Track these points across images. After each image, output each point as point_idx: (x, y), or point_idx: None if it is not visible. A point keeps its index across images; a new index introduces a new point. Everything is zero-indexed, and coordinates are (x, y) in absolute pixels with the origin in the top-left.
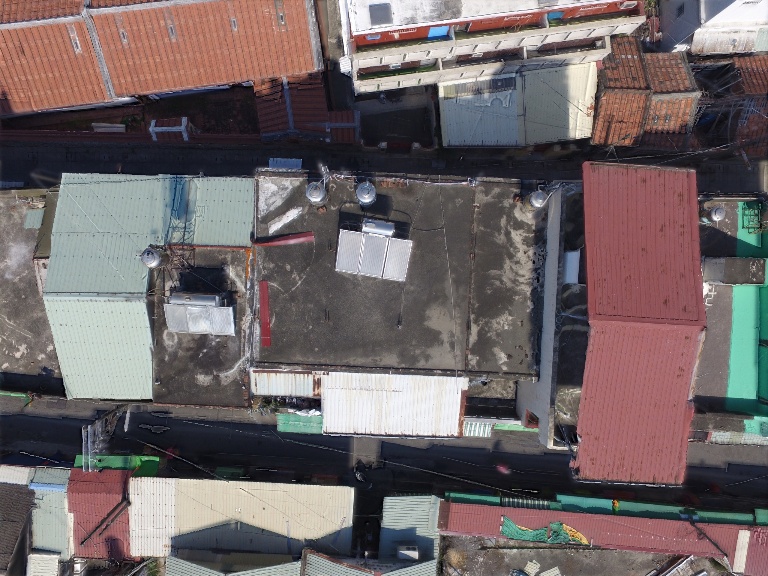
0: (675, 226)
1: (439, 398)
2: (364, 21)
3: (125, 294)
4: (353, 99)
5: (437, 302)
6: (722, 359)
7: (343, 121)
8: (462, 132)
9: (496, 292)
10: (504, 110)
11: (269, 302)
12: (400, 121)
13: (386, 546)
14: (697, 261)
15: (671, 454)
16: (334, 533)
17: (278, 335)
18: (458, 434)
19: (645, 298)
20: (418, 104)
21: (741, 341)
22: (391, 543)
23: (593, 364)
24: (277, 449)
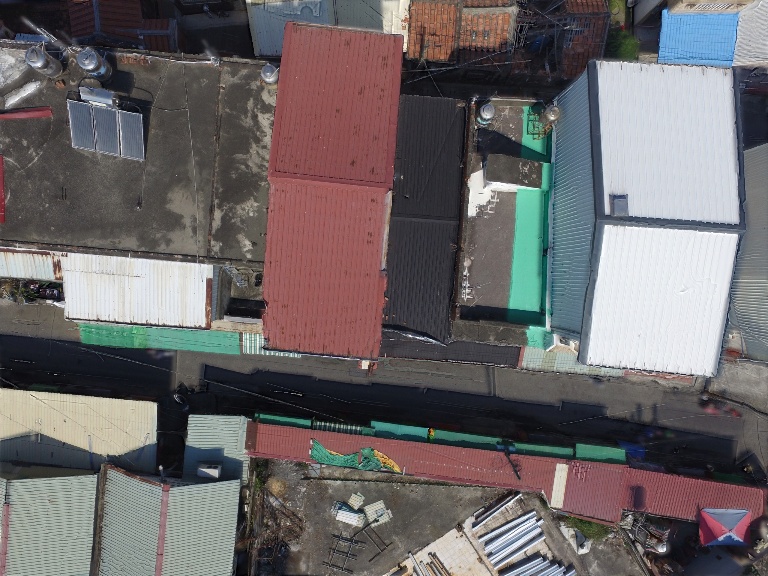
0: (374, 89)
1: (184, 286)
2: None
3: None
4: (180, 12)
5: (180, 185)
6: (504, 269)
7: (156, 28)
8: (273, 41)
9: (241, 177)
10: (315, 19)
11: (4, 178)
12: (229, 37)
13: (191, 465)
14: (393, 125)
15: (365, 327)
16: (137, 449)
17: (13, 212)
18: (205, 325)
19: (331, 158)
20: (247, 20)
21: (524, 251)
22: (196, 462)
23: (276, 225)
24: (97, 368)
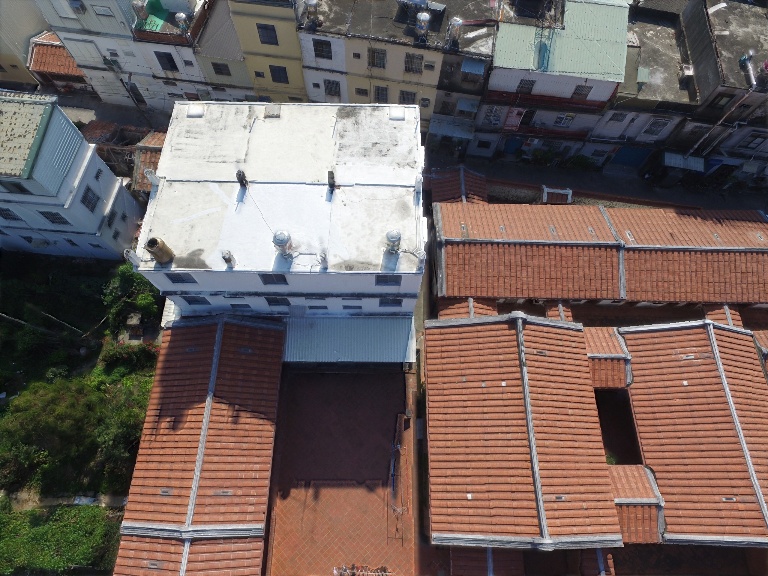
0: None
1: None
2: (410, 113)
3: (578, 1)
4: None
5: None
6: None
7: None
8: None
9: None
10: None
11: None
12: None
13: None
14: None
15: None
16: None
17: None
18: None
19: None
20: None
21: None
22: None
23: None
24: None
